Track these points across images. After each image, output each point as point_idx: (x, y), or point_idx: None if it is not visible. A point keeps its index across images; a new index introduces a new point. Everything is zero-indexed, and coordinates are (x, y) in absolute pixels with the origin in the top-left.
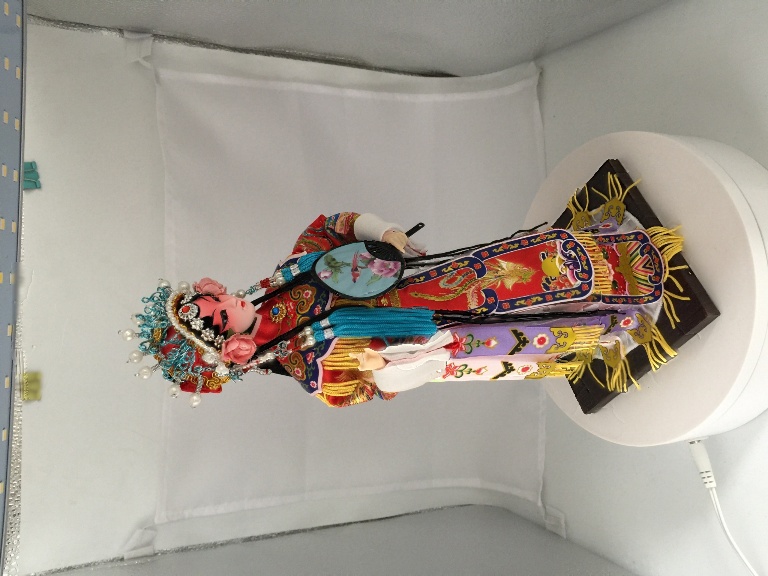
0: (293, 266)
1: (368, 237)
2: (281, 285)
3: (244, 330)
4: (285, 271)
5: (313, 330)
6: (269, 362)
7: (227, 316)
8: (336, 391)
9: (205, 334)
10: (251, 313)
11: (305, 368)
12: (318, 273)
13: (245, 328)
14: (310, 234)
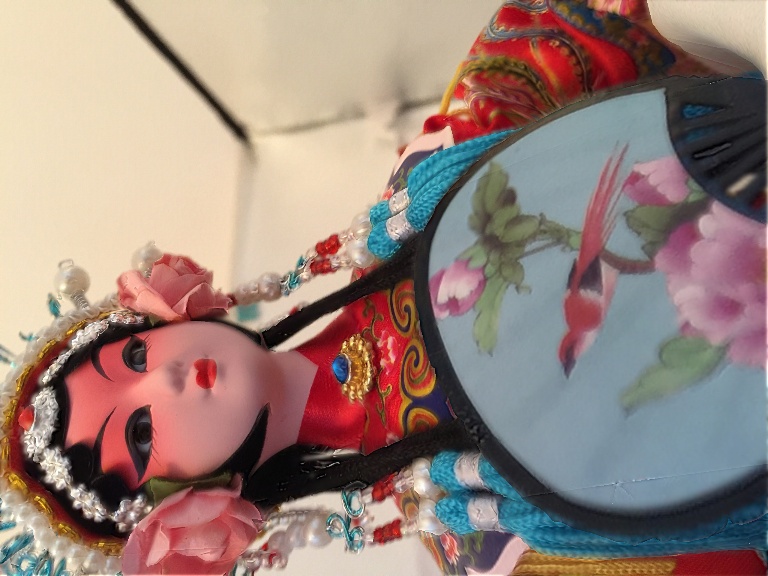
0: (397, 197)
1: (707, 35)
2: (362, 269)
3: (220, 460)
4: (375, 216)
5: (436, 484)
6: None
7: (151, 430)
8: None
9: None
10: (240, 401)
11: (441, 566)
12: (432, 274)
13: (222, 454)
14: (502, 31)
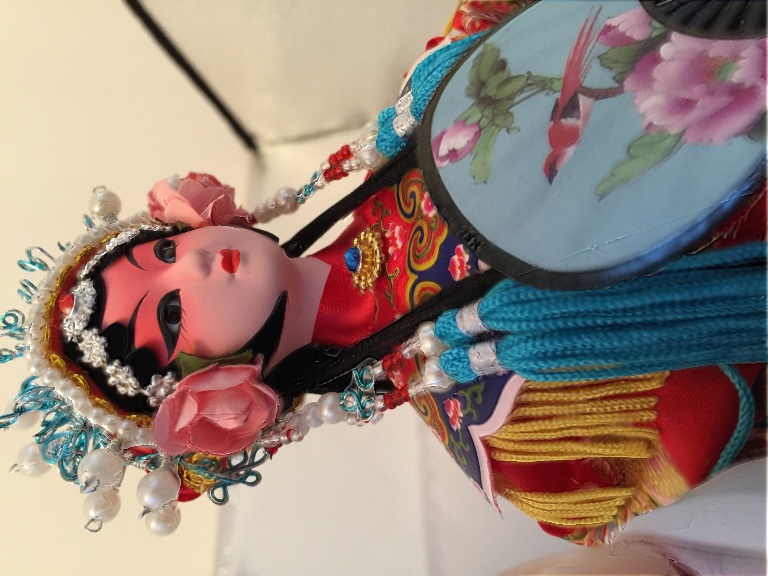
0: (403, 100)
1: None
2: (371, 169)
3: (243, 341)
4: (382, 120)
5: (440, 340)
6: (385, 376)
7: (180, 310)
8: (551, 511)
9: (116, 376)
10: (261, 286)
11: (446, 437)
12: (434, 136)
13: (245, 335)
14: None
